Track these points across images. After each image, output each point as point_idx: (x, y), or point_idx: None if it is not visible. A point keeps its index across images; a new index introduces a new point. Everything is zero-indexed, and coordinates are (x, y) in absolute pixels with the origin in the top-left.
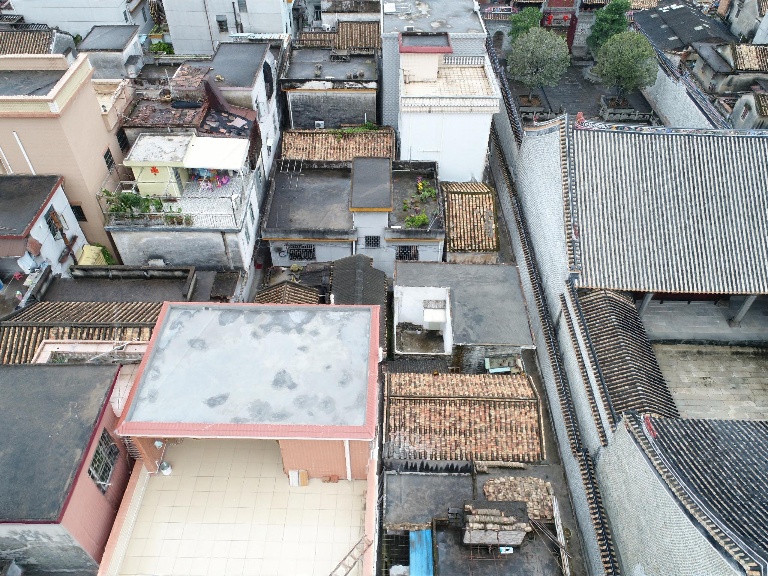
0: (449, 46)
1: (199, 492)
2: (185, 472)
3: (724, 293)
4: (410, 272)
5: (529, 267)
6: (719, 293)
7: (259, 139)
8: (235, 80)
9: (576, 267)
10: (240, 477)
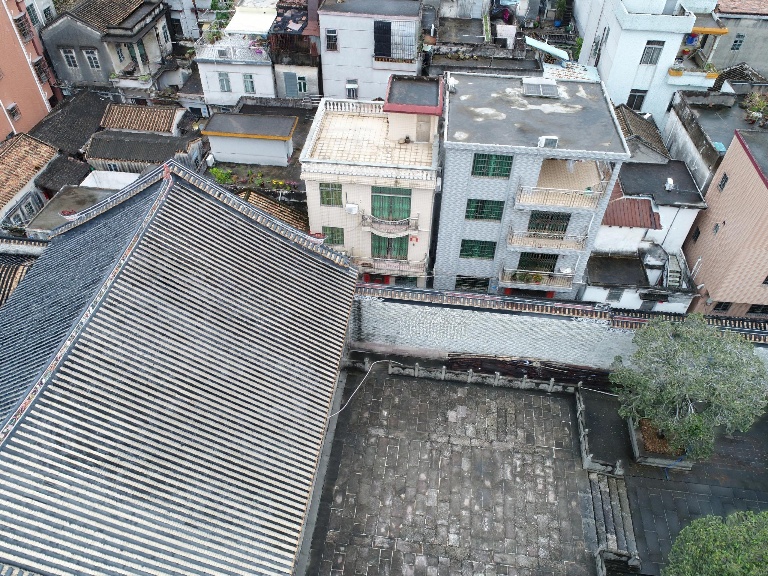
0: (391, 104)
1: None
2: None
3: None
4: None
5: None
6: None
7: (308, 56)
8: (337, 6)
9: None
10: None
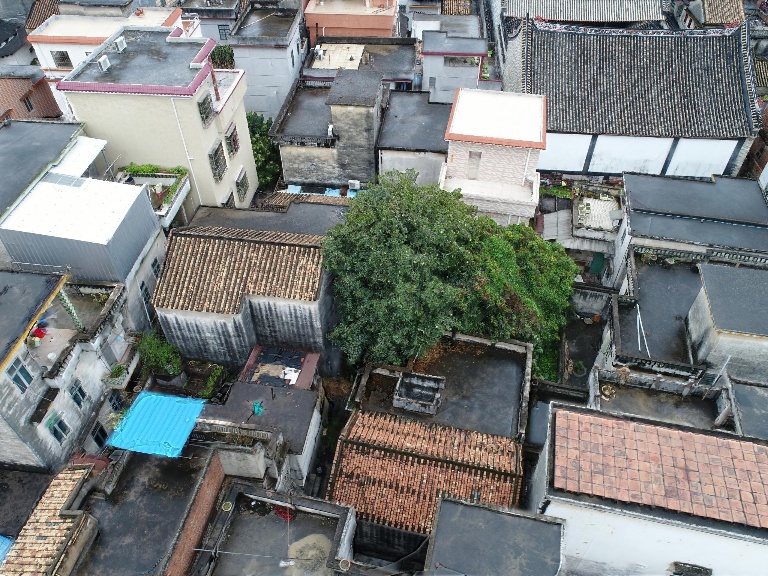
0: None
1: (334, 8)
2: (328, 5)
3: (582, 21)
4: (421, 17)
5: (486, 22)
6: (579, 21)
7: None
8: None
9: (504, 4)
10: (348, 6)
